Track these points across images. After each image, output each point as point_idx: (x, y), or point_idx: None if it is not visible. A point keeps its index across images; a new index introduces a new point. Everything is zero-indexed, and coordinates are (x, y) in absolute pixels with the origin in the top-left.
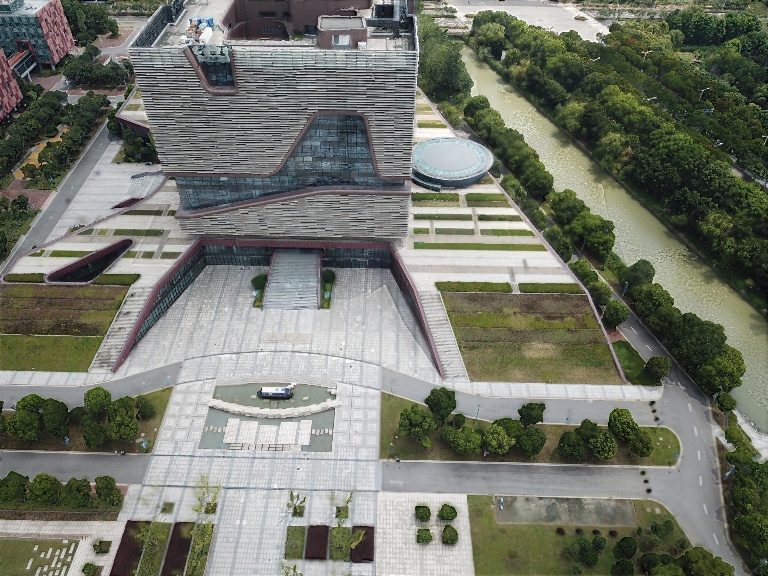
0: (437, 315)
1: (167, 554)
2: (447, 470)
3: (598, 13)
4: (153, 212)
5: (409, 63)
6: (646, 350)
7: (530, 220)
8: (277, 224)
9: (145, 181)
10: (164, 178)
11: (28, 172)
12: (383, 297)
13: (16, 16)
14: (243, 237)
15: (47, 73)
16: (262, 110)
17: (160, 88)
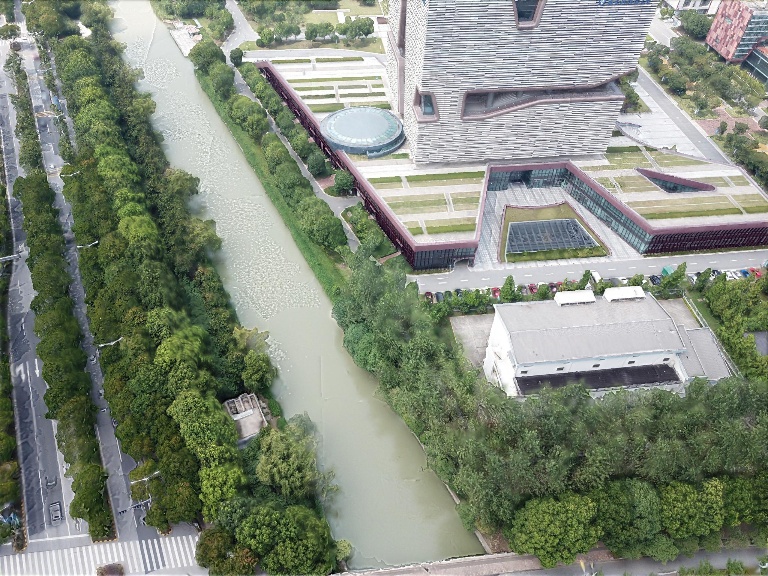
0: None
1: None
2: None
3: None
4: None
5: None
6: None
7: None
8: None
9: None
10: None
11: None
12: None
13: None
14: None
15: None
16: None
17: None
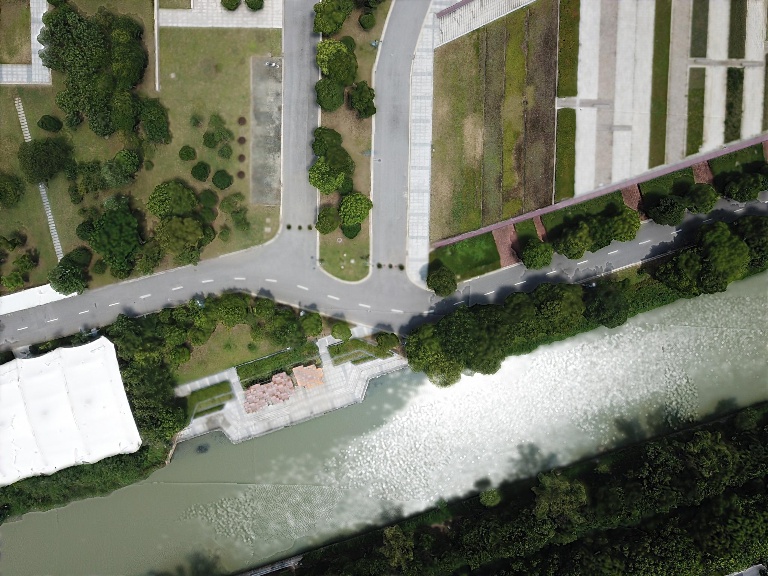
0: None
1: None
2: (311, 8)
3: None
4: None
5: None
6: (486, 288)
7: (748, 173)
8: None
9: None
10: None
11: None
12: None
13: None
14: None
15: None
16: None
17: None
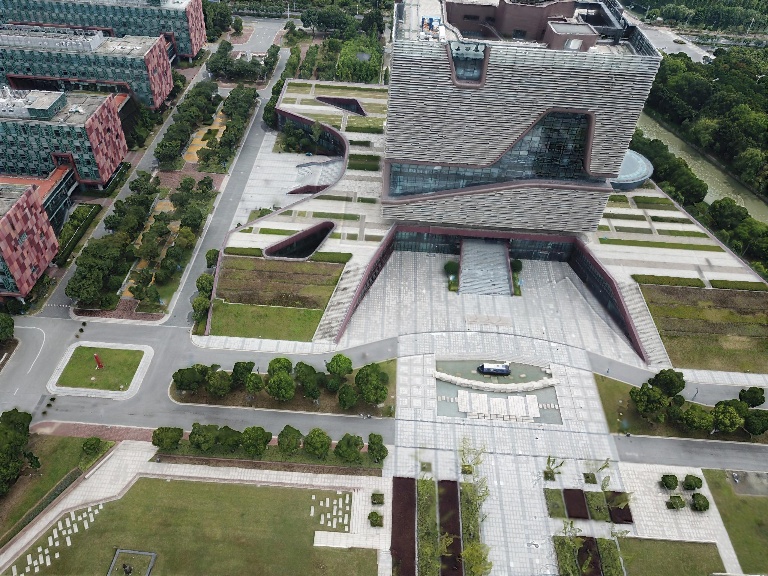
0: (637, 305)
1: (440, 508)
2: (676, 446)
3: (696, 38)
4: (343, 198)
5: (651, 68)
6: None
7: None
8: (477, 214)
9: (313, 170)
10: (343, 167)
11: (205, 156)
12: (569, 288)
13: (166, 9)
14: (437, 225)
15: (185, 65)
16: (499, 104)
17: (411, 79)
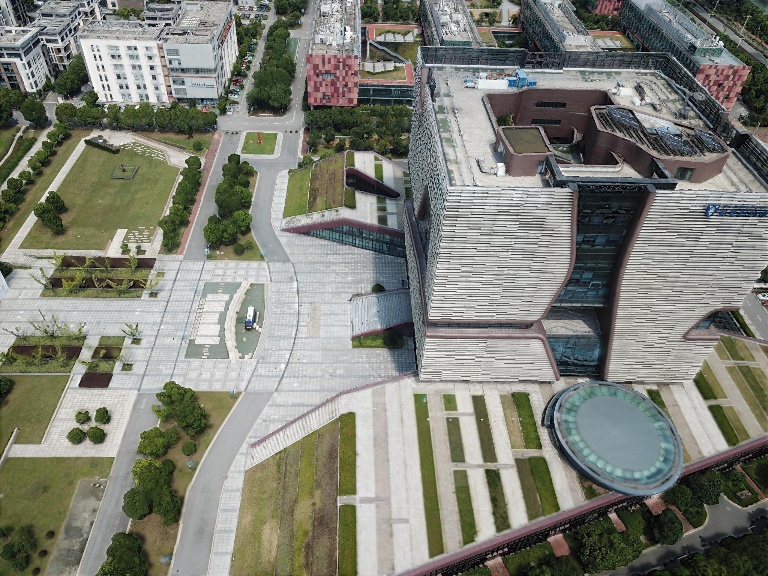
0: (315, 421)
1: None
2: None
3: None
4: None
5: None
6: None
7: None
8: None
9: None
10: None
11: None
12: None
13: (691, 59)
14: None
15: None
16: None
17: None
